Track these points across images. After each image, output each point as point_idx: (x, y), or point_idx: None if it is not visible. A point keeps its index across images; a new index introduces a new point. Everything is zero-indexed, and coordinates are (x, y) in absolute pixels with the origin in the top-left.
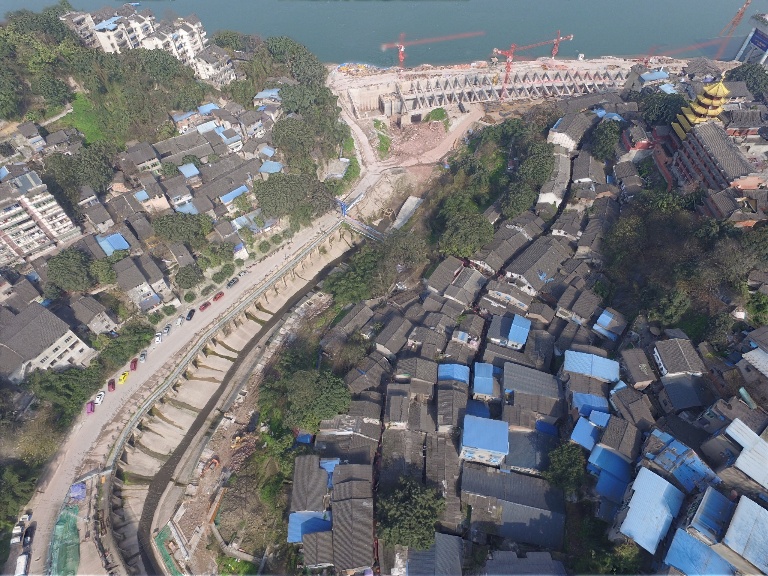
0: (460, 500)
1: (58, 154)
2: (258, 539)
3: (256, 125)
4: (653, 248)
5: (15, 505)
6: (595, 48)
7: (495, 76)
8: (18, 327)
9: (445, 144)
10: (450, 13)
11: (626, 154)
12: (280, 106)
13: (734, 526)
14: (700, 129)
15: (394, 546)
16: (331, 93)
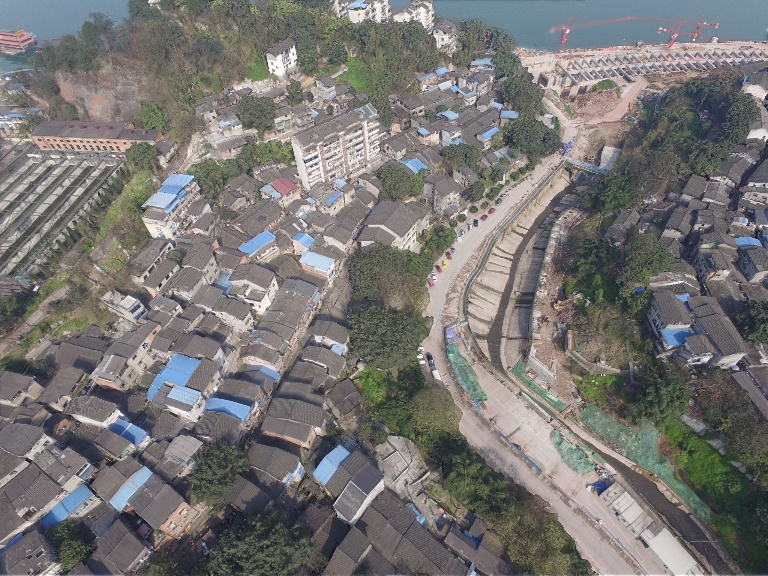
0: None
1: None
2: (618, 359)
3: (484, 84)
4: None
5: (426, 333)
6: (717, 35)
7: (642, 56)
8: (385, 215)
9: (621, 107)
10: (572, 10)
11: None
12: (494, 71)
13: None
14: None
15: (755, 347)
16: None
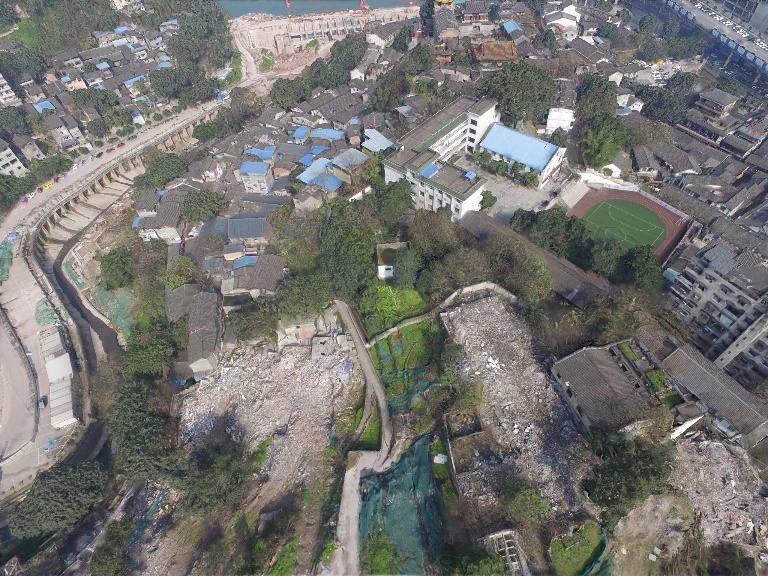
0: (240, 208)
1: (6, 52)
2: None
3: (157, 41)
4: None
5: None
6: None
7: (366, 19)
8: None
9: None
10: None
11: (411, 42)
12: (179, 30)
13: (339, 157)
14: (437, 12)
15: (193, 224)
16: (225, 26)
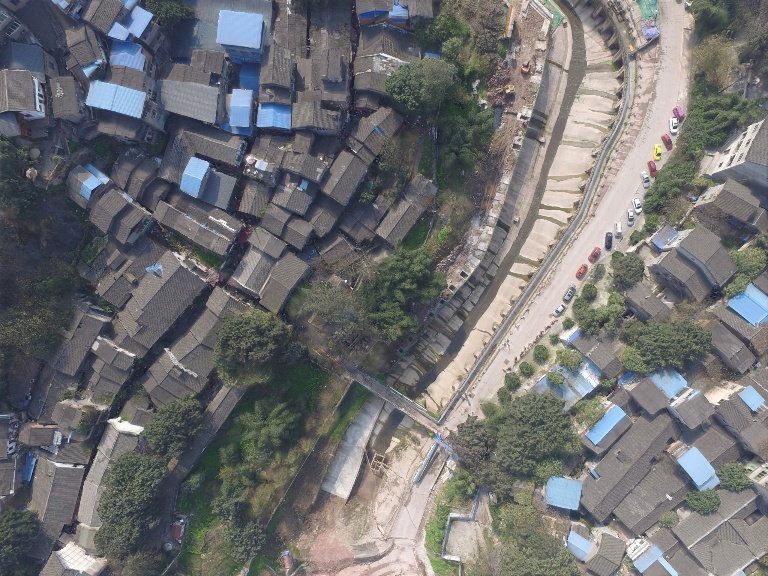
0: None
1: None
2: None
3: None
4: (1, 297)
5: None
6: None
7: None
8: None
9: None
10: None
11: None
12: None
13: None
14: None
15: None
16: None
